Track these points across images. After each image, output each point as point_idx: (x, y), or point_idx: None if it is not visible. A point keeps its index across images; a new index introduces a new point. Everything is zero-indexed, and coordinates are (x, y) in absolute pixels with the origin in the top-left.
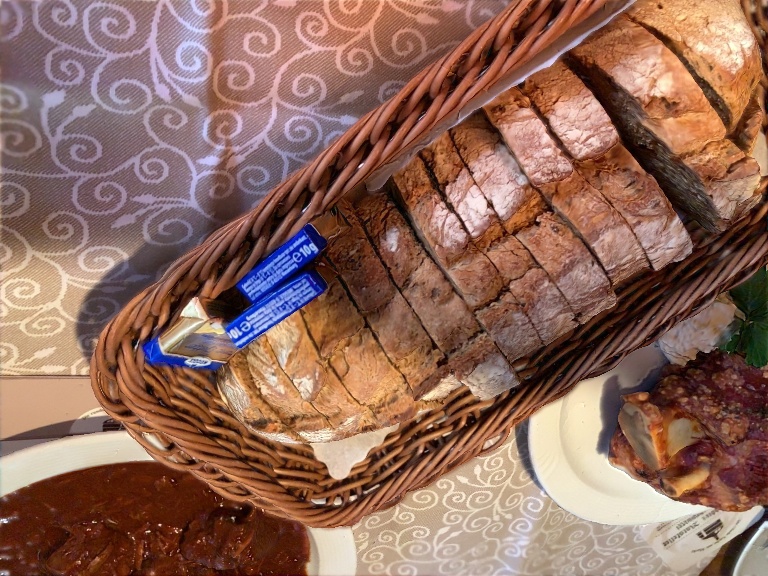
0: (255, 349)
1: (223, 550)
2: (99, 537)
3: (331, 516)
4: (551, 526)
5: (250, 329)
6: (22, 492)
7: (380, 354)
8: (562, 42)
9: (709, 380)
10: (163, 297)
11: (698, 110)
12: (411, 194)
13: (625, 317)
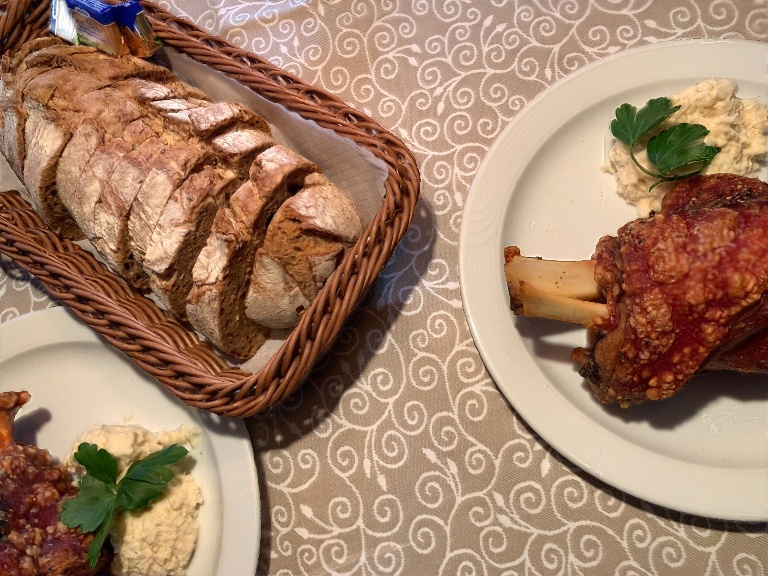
0: None
1: None
2: None
3: None
4: None
5: None
6: None
7: None
8: (277, 101)
9: (45, 479)
10: None
11: None
12: None
13: None
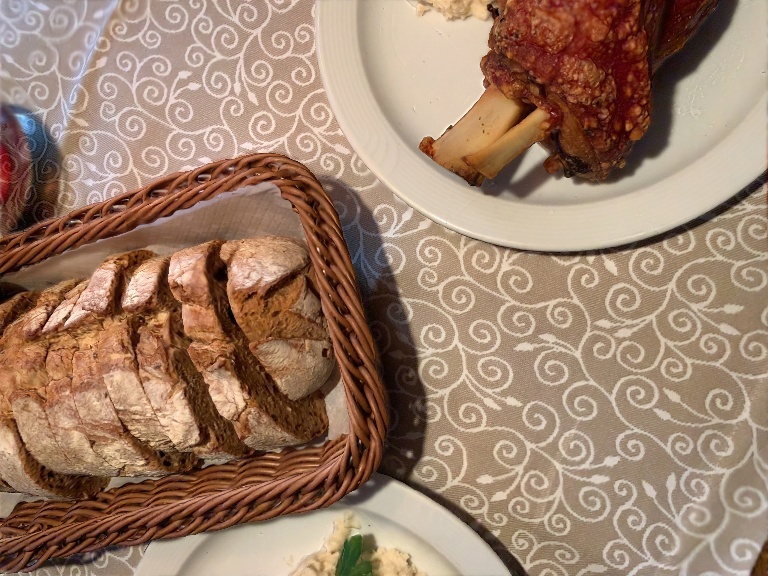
0: None
1: None
2: None
3: None
4: None
5: None
6: None
7: None
8: (134, 225)
9: None
10: None
11: (199, 303)
12: (41, 295)
13: None
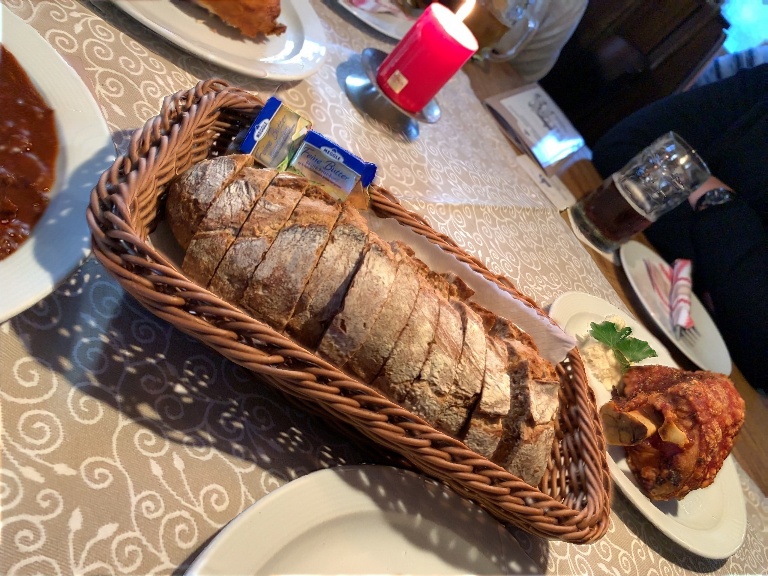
0: None
1: None
2: None
3: None
4: None
5: None
6: None
7: None
8: None
9: None
10: None
11: (534, 347)
12: None
13: None
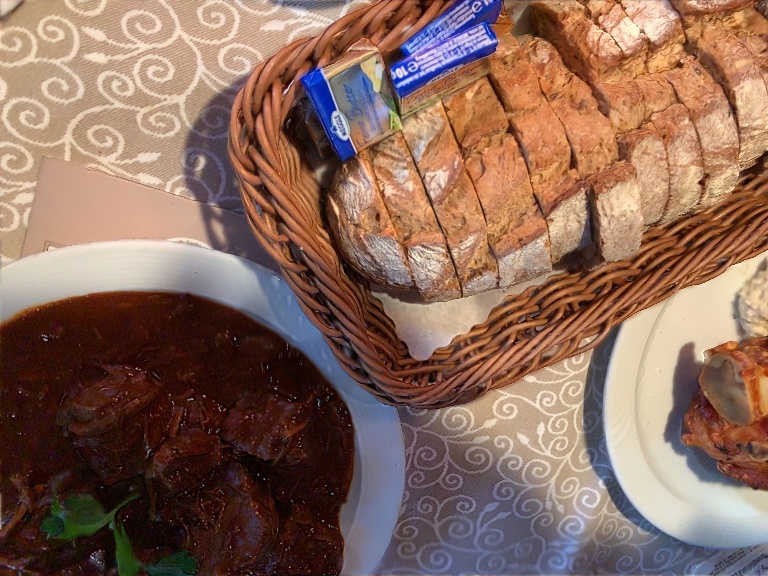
0: (387, 148)
1: (274, 428)
2: (140, 385)
3: (412, 387)
4: (602, 536)
5: (417, 70)
6: (77, 303)
7: (520, 159)
8: None
9: None
10: (333, 33)
11: None
12: (568, 13)
13: (731, 228)
